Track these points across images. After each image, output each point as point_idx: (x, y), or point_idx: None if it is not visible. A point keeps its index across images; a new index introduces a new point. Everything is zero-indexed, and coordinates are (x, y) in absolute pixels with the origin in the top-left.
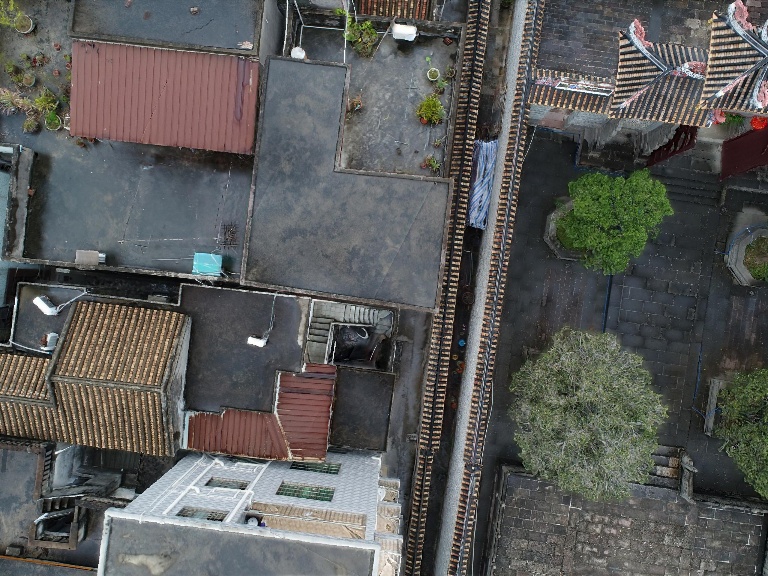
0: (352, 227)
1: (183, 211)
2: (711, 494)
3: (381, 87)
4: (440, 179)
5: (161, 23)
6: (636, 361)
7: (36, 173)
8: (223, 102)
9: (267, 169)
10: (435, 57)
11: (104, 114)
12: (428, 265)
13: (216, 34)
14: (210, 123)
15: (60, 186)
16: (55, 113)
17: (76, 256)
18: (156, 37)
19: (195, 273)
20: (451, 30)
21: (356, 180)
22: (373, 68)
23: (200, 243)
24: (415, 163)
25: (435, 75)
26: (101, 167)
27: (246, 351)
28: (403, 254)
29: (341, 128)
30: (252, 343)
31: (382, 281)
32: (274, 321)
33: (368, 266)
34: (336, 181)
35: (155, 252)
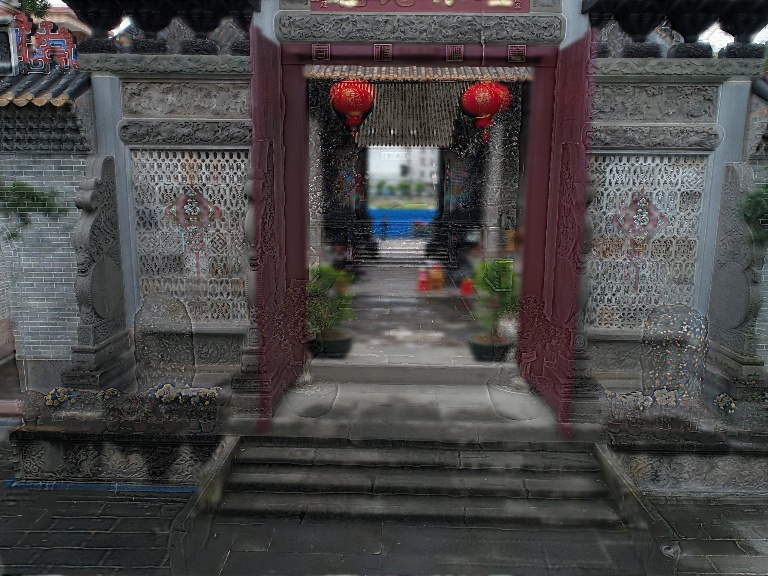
0: None
1: None
2: (316, 254)
3: None
4: None
5: None
6: (513, 95)
7: None
8: None
9: None
10: None
11: None
12: None
13: None
14: None
15: None
16: None
17: None
18: None
19: None
20: None
21: None
22: None
23: None
24: None
25: None
26: None
27: None
28: None
29: None
30: None
31: None
32: None
33: None
34: None
35: None
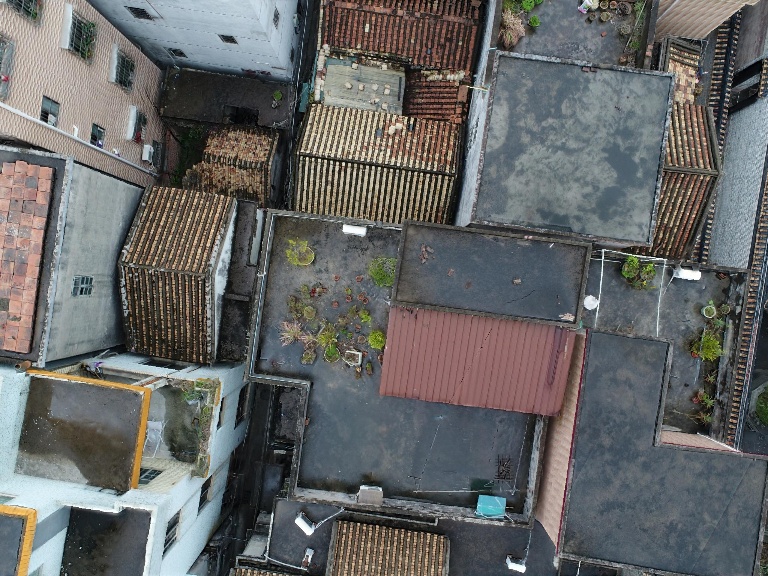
0: (670, 502)
1: (458, 444)
2: None
3: (652, 319)
4: (760, 457)
5: (483, 293)
6: None
7: (311, 402)
8: (536, 367)
9: (586, 442)
10: (707, 291)
11: (416, 375)
12: (745, 541)
13: (537, 305)
14: (521, 386)
15: (335, 416)
16: (335, 346)
17: (360, 495)
18: (477, 307)
19: (479, 515)
20: (735, 274)
21: (675, 455)
22: (645, 300)
23: (474, 476)
24: (685, 396)
25: (711, 313)
26: (377, 398)
27: (501, 571)
28: (720, 530)
29: (662, 404)
30: (514, 569)
31: (699, 556)
32: (530, 542)
33: (685, 541)
34: (655, 455)
35: (428, 484)
